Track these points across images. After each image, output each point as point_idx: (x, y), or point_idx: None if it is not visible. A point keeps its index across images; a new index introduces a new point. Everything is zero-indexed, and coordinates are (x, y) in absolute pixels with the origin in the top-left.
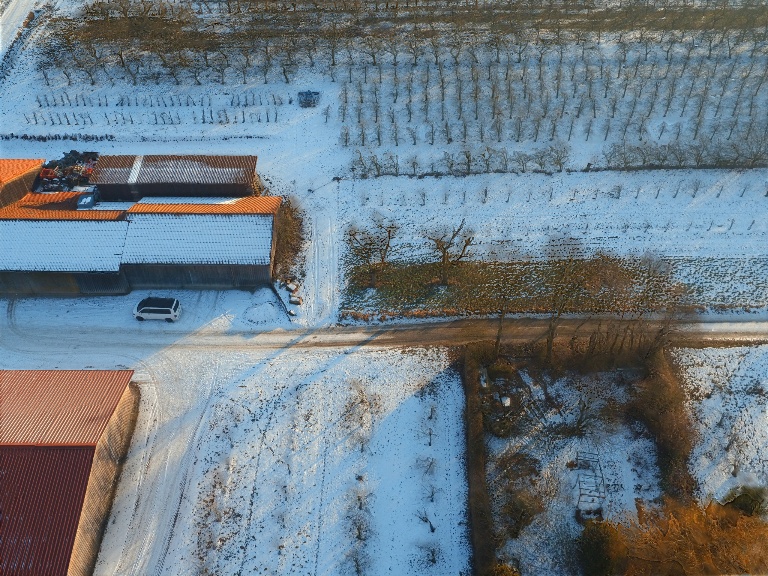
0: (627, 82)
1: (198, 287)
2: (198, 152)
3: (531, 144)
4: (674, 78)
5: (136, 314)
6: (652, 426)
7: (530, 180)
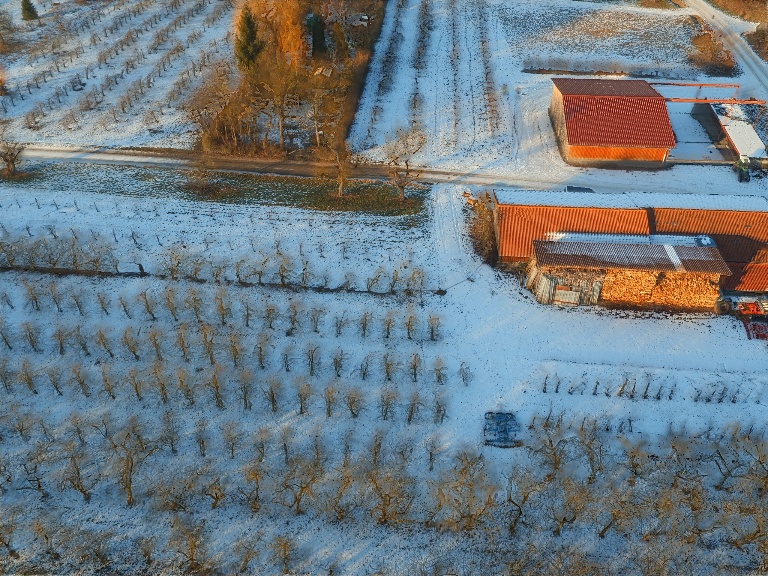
0: None
1: None
2: (637, 348)
3: None
4: None
5: None
6: None
7: None
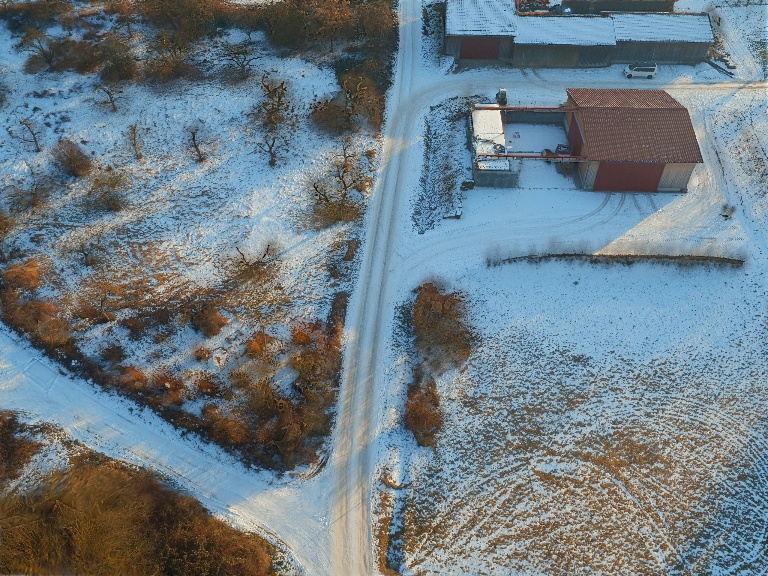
0: None
1: None
2: None
3: None
4: None
5: (629, 72)
6: None
7: None
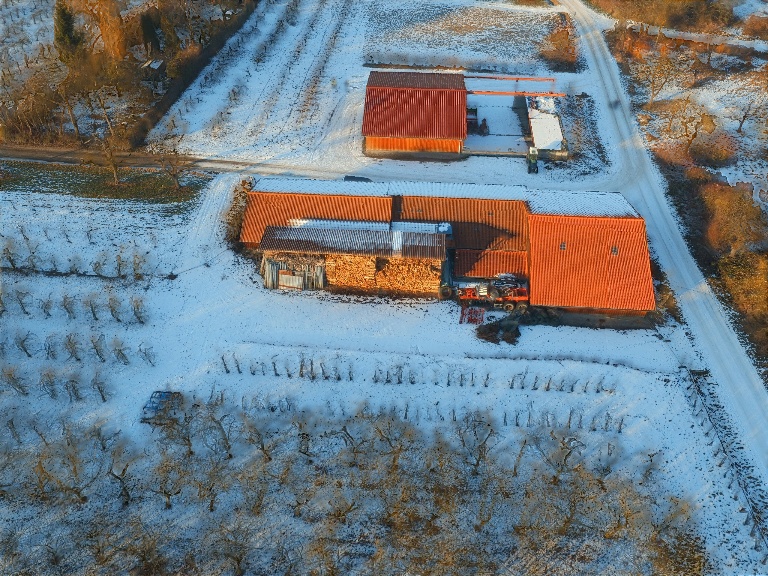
0: None
1: None
2: (343, 331)
3: None
4: None
5: None
6: None
7: None
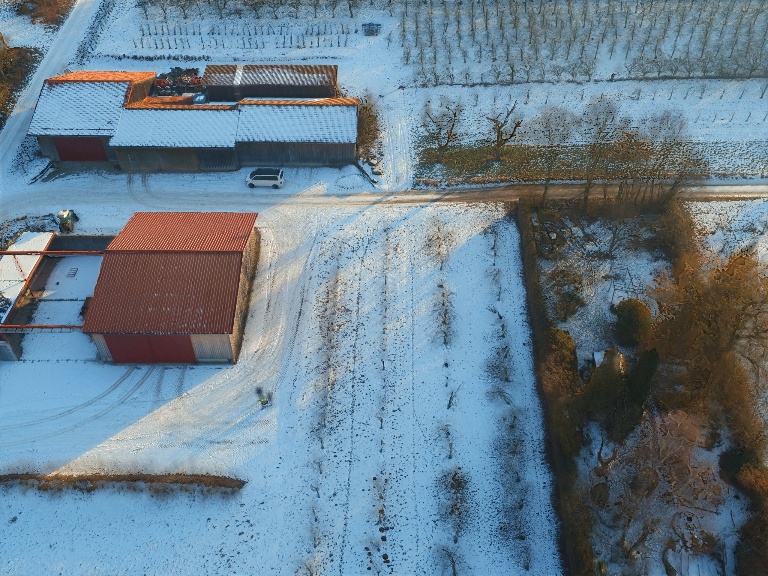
0: (644, 13)
1: (295, 165)
2: None
3: (563, 61)
4: (684, 10)
5: (249, 181)
6: (669, 252)
7: (564, 88)
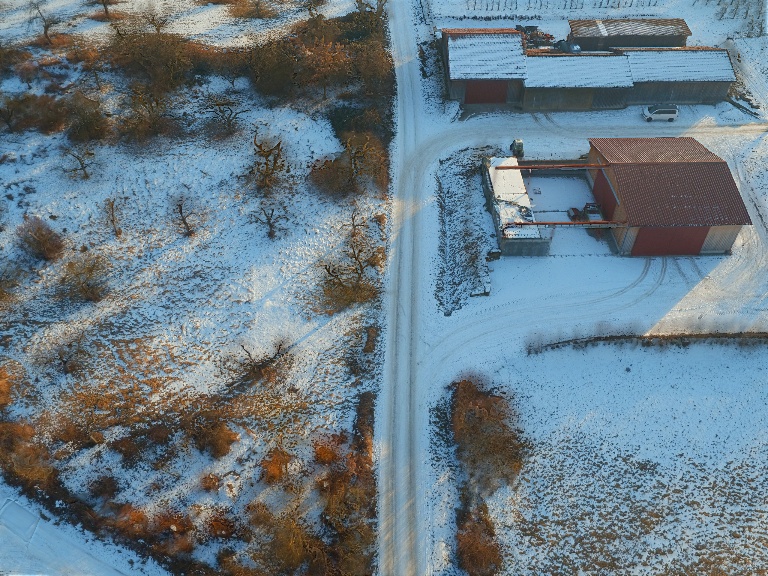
0: None
1: (673, 103)
2: None
3: None
4: None
5: (649, 116)
6: None
7: None
